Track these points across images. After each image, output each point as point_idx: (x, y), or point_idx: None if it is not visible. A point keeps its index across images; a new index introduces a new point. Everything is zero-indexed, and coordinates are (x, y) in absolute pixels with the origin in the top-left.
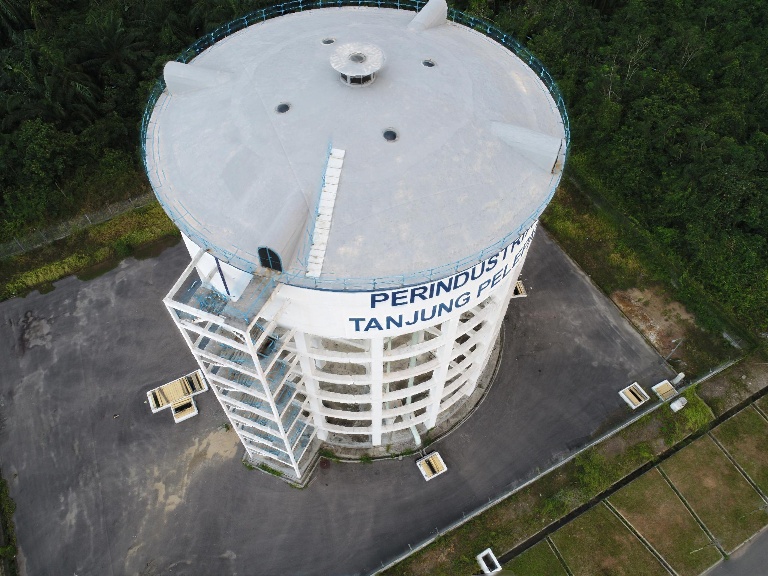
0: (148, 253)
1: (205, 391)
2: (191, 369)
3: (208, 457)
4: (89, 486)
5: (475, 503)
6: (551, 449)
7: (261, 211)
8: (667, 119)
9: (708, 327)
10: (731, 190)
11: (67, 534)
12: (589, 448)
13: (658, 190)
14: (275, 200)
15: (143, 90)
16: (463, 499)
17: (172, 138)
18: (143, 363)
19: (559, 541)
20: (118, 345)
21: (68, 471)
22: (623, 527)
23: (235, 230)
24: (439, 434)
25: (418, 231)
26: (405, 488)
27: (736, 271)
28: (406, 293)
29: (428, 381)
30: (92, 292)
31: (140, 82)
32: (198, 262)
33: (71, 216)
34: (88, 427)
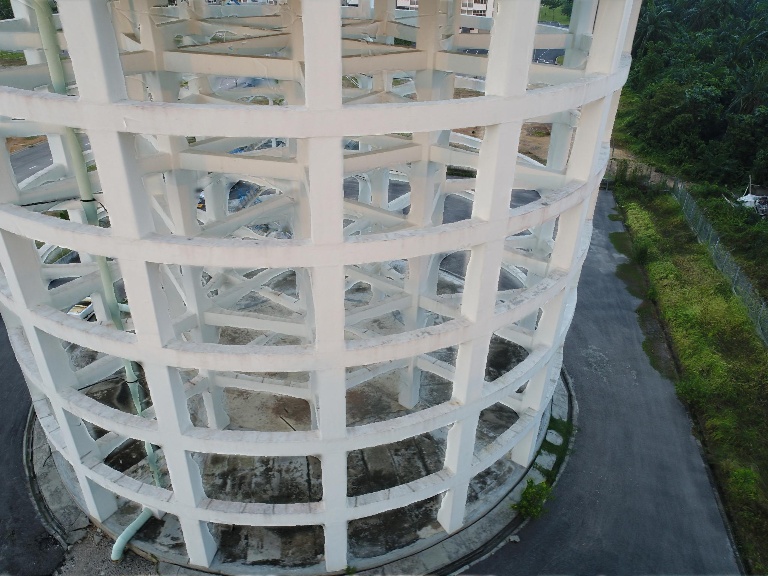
0: (627, 272)
1: None
2: None
3: None
4: None
5: None
6: None
7: None
8: None
9: None
10: None
11: (350, 178)
12: None
13: None
14: None
15: None
16: None
17: None
18: None
19: None
20: None
21: (397, 186)
22: None
23: None
24: None
25: None
26: None
27: None
28: None
29: None
30: None
31: None
32: None
33: (744, 257)
34: None
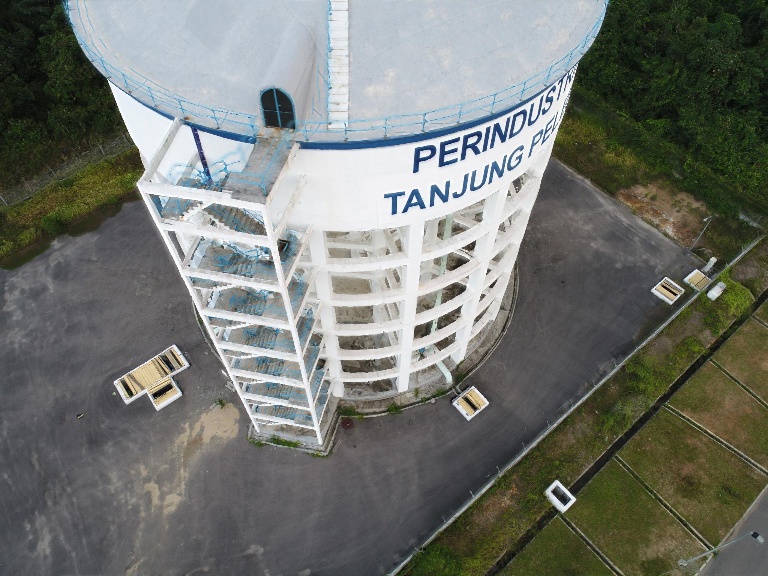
0: (84, 227)
1: (186, 368)
2: (163, 346)
3: (205, 442)
4: (60, 504)
5: (528, 434)
6: (596, 361)
7: (250, 58)
8: (635, 7)
9: (722, 211)
10: (720, 64)
11: (42, 567)
12: (637, 352)
13: (638, 83)
14: (267, 41)
15: (45, 47)
16: (514, 432)
17: (105, 2)
18: (102, 350)
19: (629, 457)
20: (67, 335)
21: (30, 492)
22: (692, 429)
23: (219, 88)
24: (470, 367)
25: (462, 56)
26: (446, 433)
27: (737, 150)
28: (457, 143)
29: (463, 293)
30: (22, 281)
31: (40, 38)
32: (166, 166)
33: None
34: (46, 435)
